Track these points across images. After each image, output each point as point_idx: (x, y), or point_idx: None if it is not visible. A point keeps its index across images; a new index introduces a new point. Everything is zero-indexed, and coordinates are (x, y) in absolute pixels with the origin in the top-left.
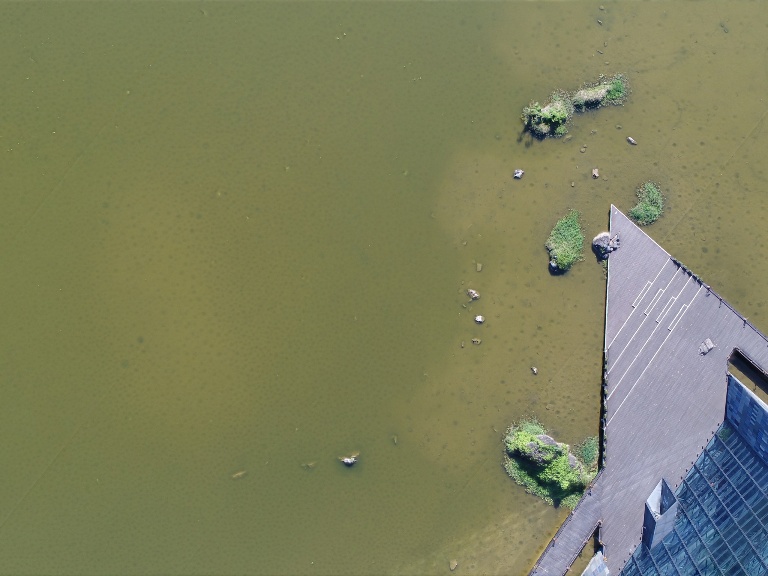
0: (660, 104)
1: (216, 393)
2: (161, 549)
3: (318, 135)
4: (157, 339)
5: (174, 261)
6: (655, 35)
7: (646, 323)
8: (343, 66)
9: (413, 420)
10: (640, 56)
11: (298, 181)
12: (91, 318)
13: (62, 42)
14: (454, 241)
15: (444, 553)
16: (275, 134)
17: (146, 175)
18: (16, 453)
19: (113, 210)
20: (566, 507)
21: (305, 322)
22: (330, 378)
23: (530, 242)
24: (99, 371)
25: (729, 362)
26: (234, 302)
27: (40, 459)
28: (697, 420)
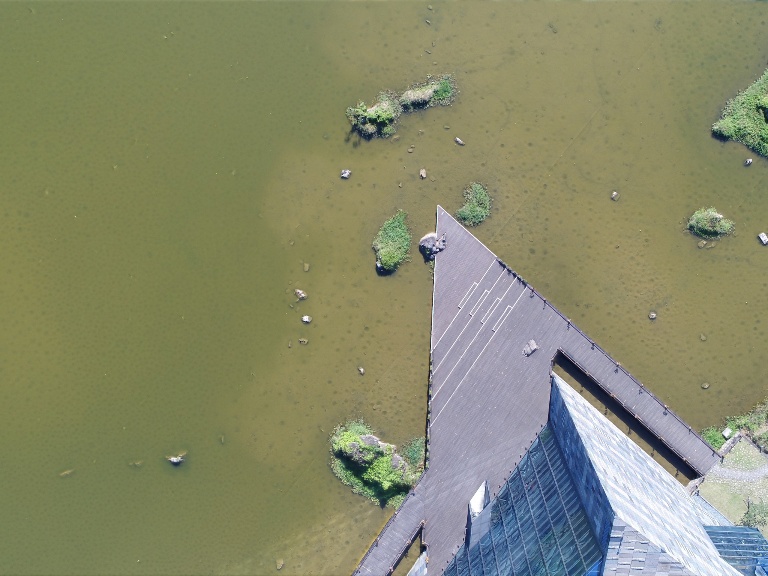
0: (488, 105)
1: (44, 392)
2: None
3: (146, 134)
4: None
5: (2, 260)
6: (483, 35)
7: (471, 324)
8: (171, 65)
9: (240, 420)
10: (468, 56)
11: (126, 180)
12: None
13: None
14: (281, 241)
15: (271, 552)
16: (103, 133)
17: None
18: None
19: None
20: (392, 507)
21: (133, 321)
22: (157, 377)
23: (357, 242)
24: None
25: (555, 363)
26: (62, 301)
27: None
28: (521, 421)
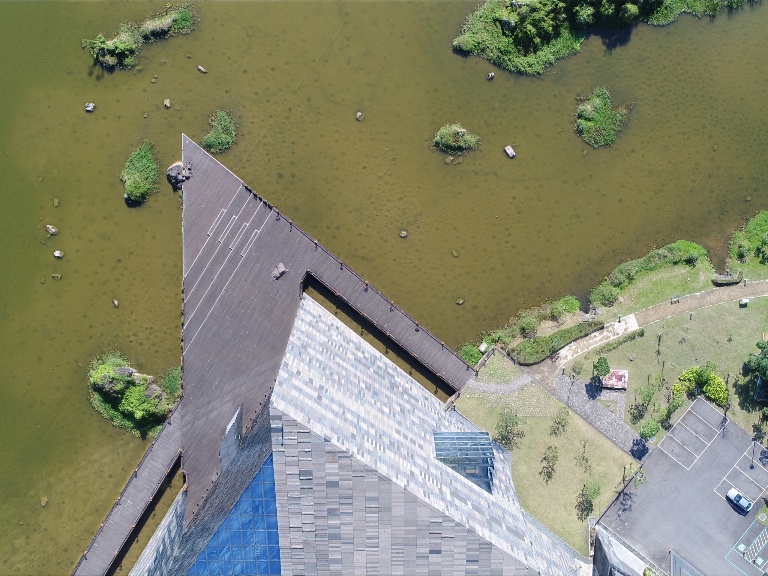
0: (229, 31)
1: None
2: None
3: None
4: None
5: None
6: None
7: (220, 250)
8: None
9: None
10: None
11: None
12: None
13: None
14: (30, 177)
15: (35, 490)
16: None
17: None
18: None
19: None
20: (153, 438)
21: None
22: None
23: (106, 175)
24: None
25: (308, 286)
26: None
27: None
28: (273, 345)
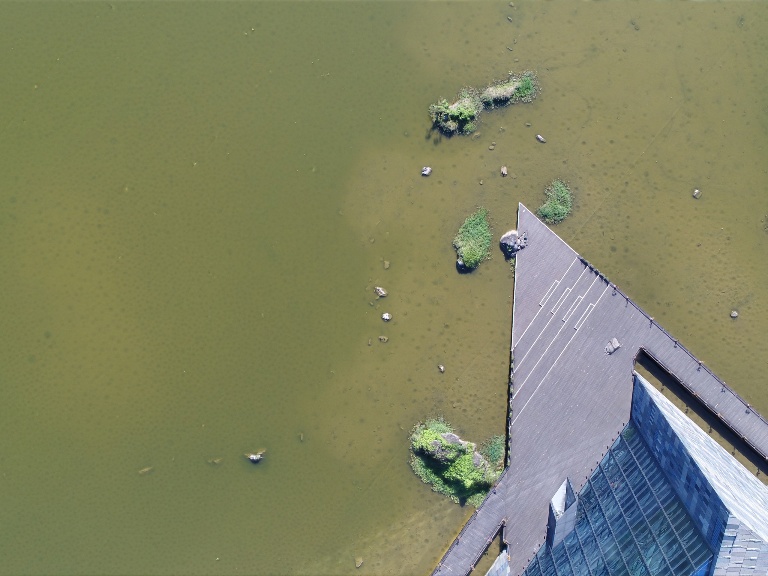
0: (570, 102)
1: (123, 389)
2: (67, 544)
3: (226, 131)
4: (64, 334)
5: (81, 256)
6: (565, 32)
7: (553, 322)
8: (251, 62)
9: (320, 417)
10: (550, 53)
11: (206, 177)
12: None
13: None
14: (362, 238)
15: (350, 550)
16: (183, 130)
17: (53, 170)
18: None
19: (20, 205)
20: (472, 506)
21: (212, 318)
22: (237, 375)
23: (438, 240)
24: (6, 366)
25: (636, 362)
26: (141, 298)
27: None
28: (602, 420)
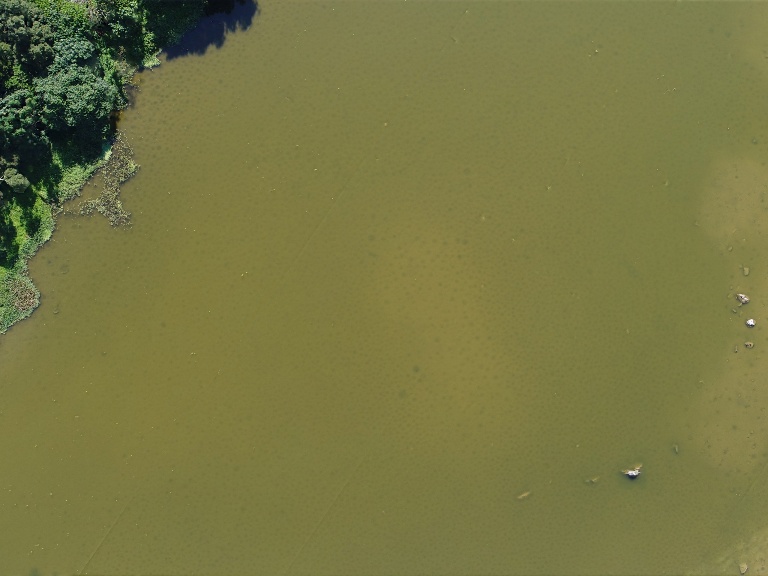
0: None
1: (495, 416)
2: (452, 575)
3: (577, 153)
4: (432, 367)
5: (444, 288)
6: None
7: None
8: (596, 83)
9: (692, 428)
10: None
11: (561, 200)
12: (365, 351)
13: (316, 79)
14: (719, 247)
15: (733, 557)
16: (535, 155)
17: (409, 205)
18: (300, 492)
19: (379, 242)
20: None
21: (578, 339)
22: (607, 392)
23: None
24: (377, 403)
25: None
26: (506, 324)
27: (325, 496)
28: None
